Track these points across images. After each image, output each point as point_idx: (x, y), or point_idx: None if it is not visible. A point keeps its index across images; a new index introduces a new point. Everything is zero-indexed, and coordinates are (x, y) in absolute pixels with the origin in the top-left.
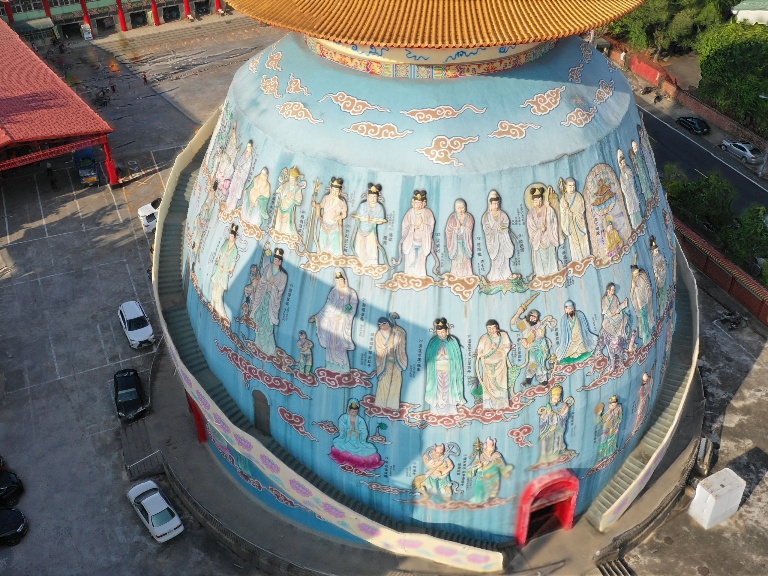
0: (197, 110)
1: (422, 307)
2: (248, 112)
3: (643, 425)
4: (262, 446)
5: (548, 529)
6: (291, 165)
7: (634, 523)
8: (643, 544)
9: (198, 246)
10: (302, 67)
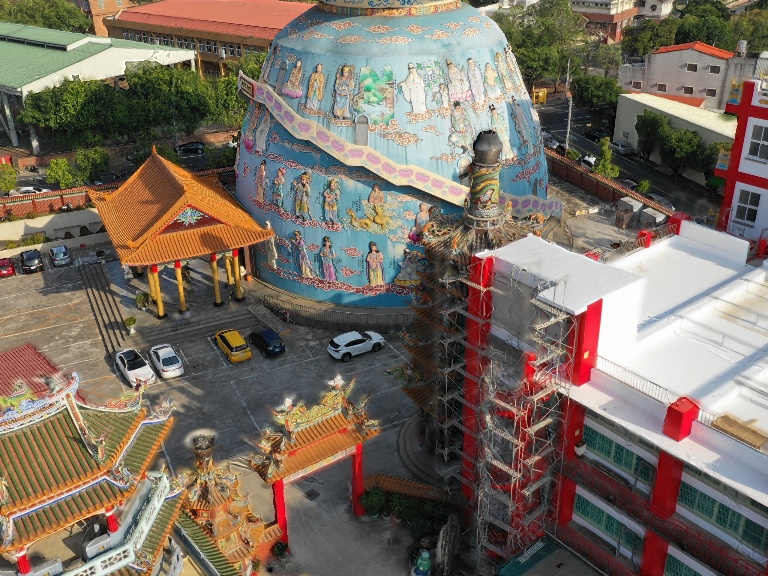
0: None
1: None
2: (453, 49)
3: None
4: None
5: None
6: None
7: None
8: None
9: None
10: (441, 19)
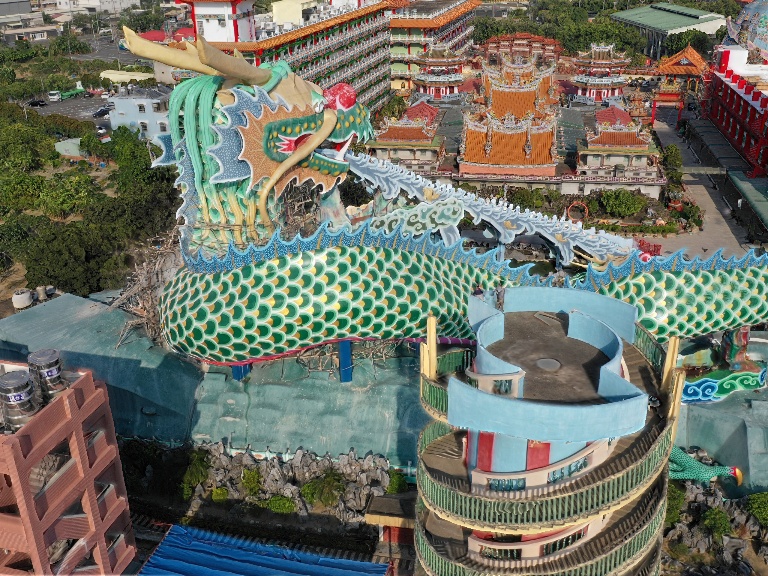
0: None
1: None
2: None
3: None
4: None
5: None
6: None
7: None
8: None
9: None
10: None
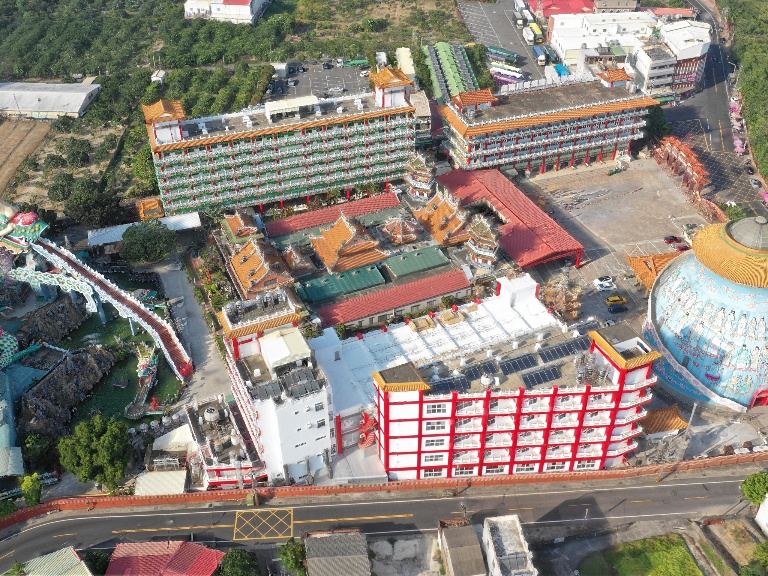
0: (595, 229)
1: (740, 341)
2: (696, 284)
3: None
4: None
5: (759, 405)
6: (711, 302)
7: None
8: None
9: (671, 315)
10: (713, 276)
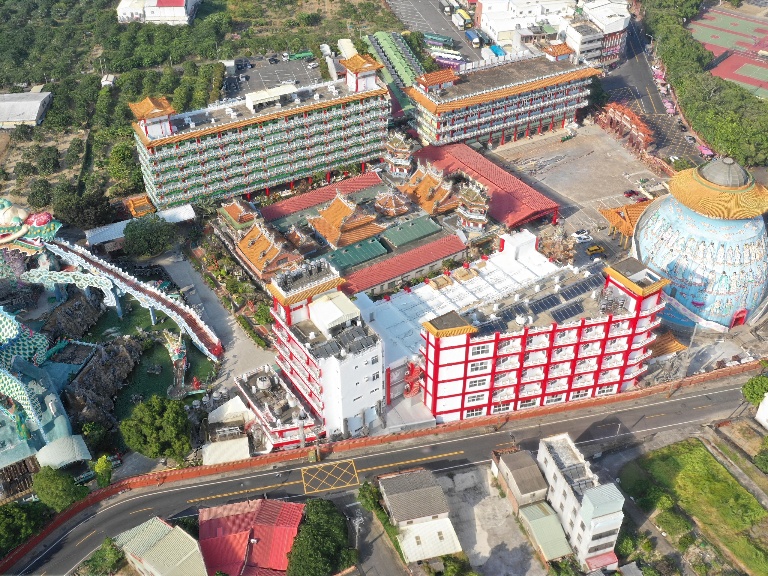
0: (561, 190)
1: (720, 269)
2: (676, 224)
3: (761, 301)
4: (676, 300)
5: (737, 325)
6: None
7: (758, 324)
8: (761, 330)
9: (656, 253)
10: (690, 214)
